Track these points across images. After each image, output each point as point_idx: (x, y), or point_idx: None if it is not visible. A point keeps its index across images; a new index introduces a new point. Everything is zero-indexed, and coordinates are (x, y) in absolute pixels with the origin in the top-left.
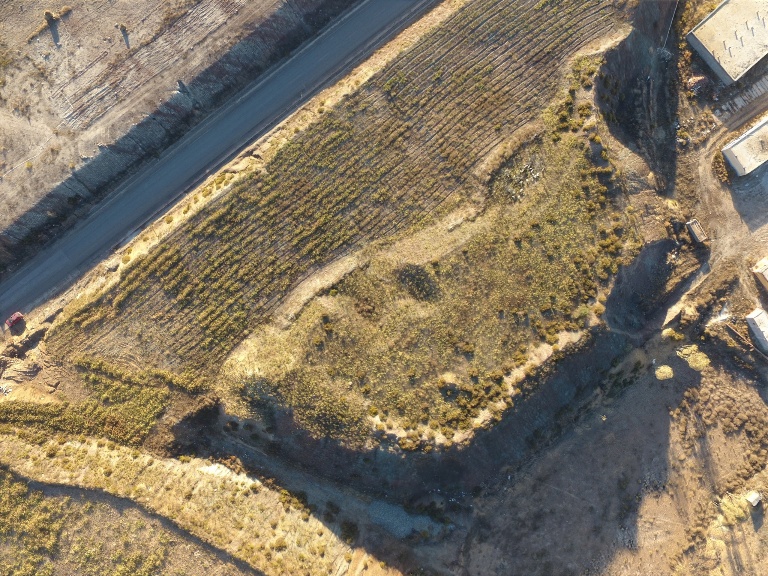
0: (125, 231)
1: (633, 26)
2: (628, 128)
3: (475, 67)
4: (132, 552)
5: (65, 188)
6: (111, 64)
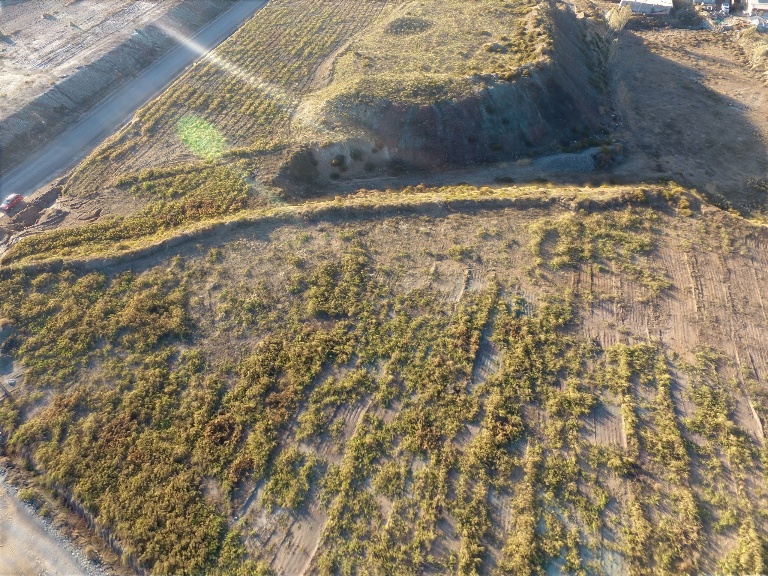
0: (125, 115)
1: None
2: None
3: None
4: (314, 268)
5: (49, 99)
6: (69, 38)
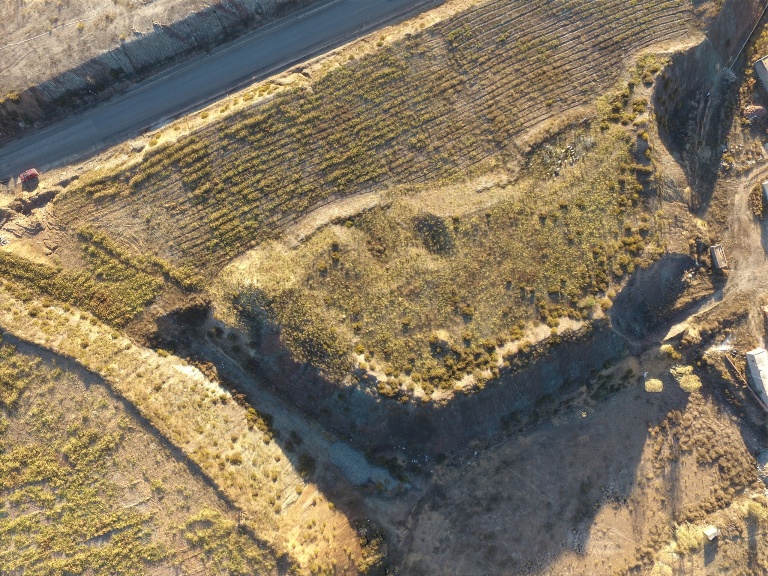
0: (158, 116)
1: (707, 36)
2: (676, 138)
3: (542, 38)
4: (89, 428)
5: (110, 58)
6: None
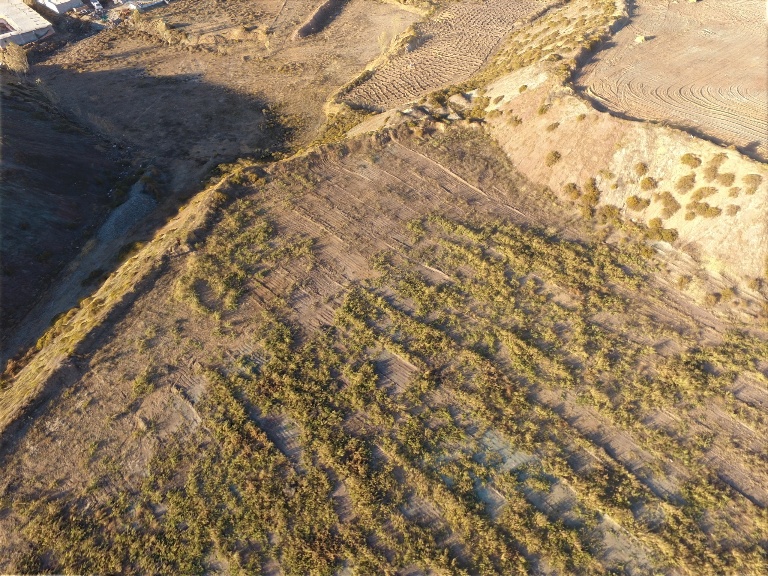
0: None
1: None
2: None
3: None
4: None
5: None
6: None
